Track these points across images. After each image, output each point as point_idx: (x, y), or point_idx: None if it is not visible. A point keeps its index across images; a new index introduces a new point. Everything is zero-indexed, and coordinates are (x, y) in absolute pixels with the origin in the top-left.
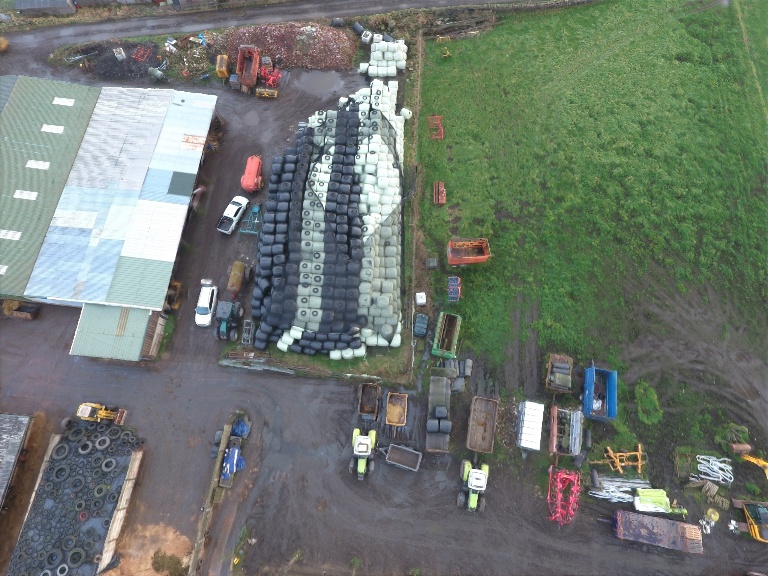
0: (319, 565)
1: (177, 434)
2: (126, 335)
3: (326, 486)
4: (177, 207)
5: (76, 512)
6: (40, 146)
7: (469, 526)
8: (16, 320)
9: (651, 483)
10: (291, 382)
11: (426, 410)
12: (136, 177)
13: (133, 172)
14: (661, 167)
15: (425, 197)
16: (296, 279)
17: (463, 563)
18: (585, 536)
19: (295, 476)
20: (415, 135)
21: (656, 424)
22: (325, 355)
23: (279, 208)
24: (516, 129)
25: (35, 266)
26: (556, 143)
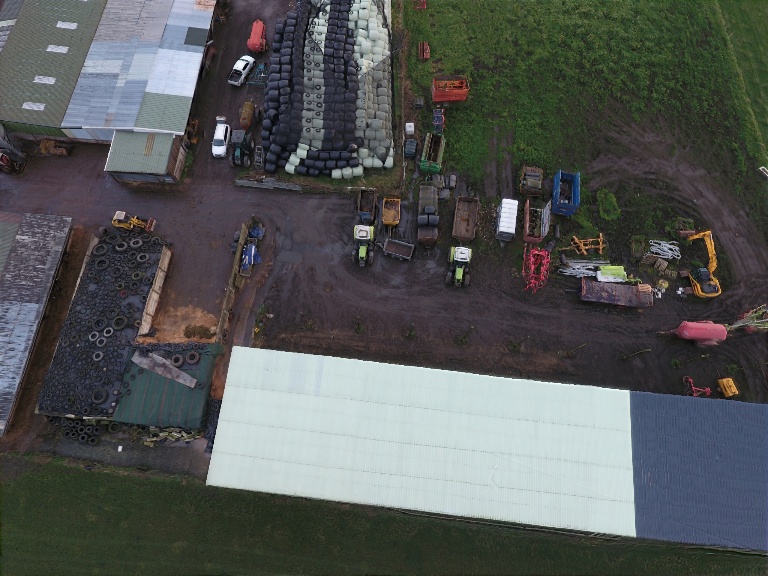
0: (328, 331)
1: (200, 239)
2: (153, 154)
3: (332, 274)
4: (193, 54)
5: (117, 291)
6: (68, 11)
7: (456, 300)
8: (52, 157)
9: (611, 263)
10: (299, 197)
11: (417, 215)
12: (156, 31)
13: (153, 28)
14: (618, 26)
15: (411, 54)
16: (301, 105)
17: (452, 327)
18: (555, 303)
19: (305, 268)
20: (401, 6)
21: (615, 220)
22: (327, 176)
23: (283, 53)
24: (490, 0)
25: (70, 104)
26: (526, 10)
